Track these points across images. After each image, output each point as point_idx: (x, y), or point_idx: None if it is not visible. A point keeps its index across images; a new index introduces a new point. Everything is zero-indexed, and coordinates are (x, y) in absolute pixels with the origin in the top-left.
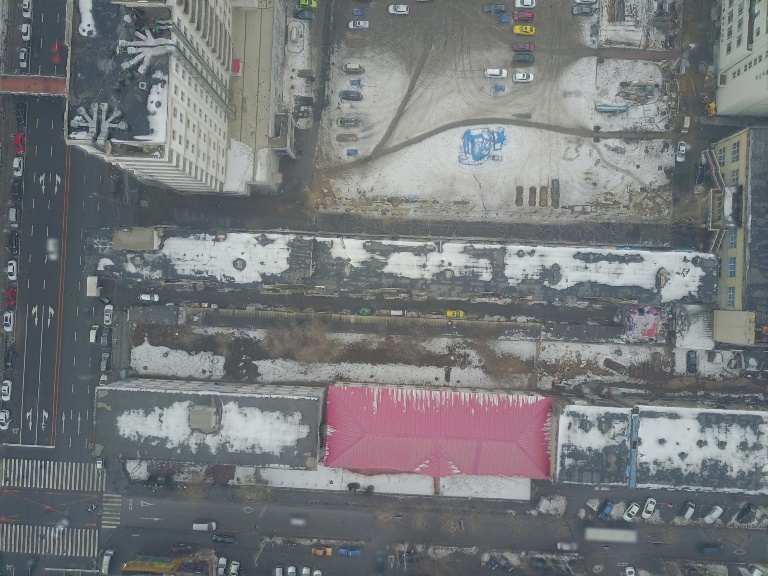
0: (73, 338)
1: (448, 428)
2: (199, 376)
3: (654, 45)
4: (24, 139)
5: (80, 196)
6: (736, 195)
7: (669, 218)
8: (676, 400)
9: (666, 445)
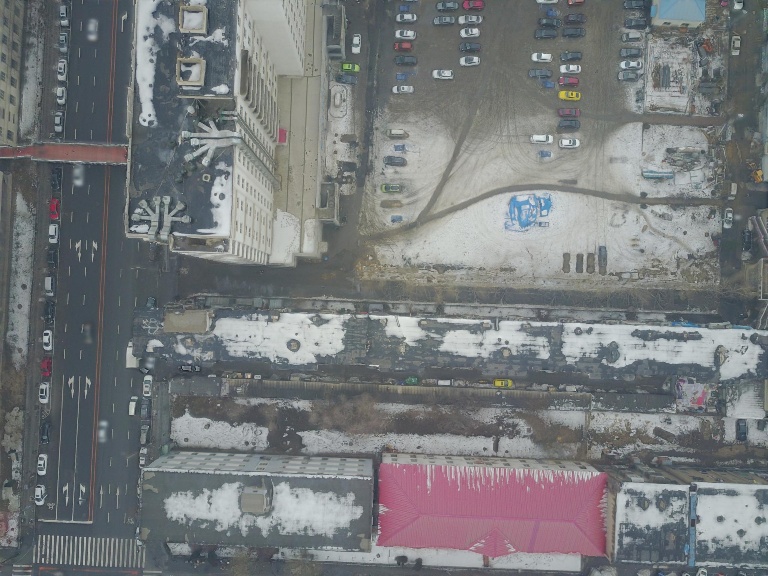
0: (111, 410)
1: (504, 507)
2: (242, 448)
3: (700, 111)
4: (59, 205)
5: (117, 263)
6: None
7: None
8: (728, 471)
9: (724, 522)
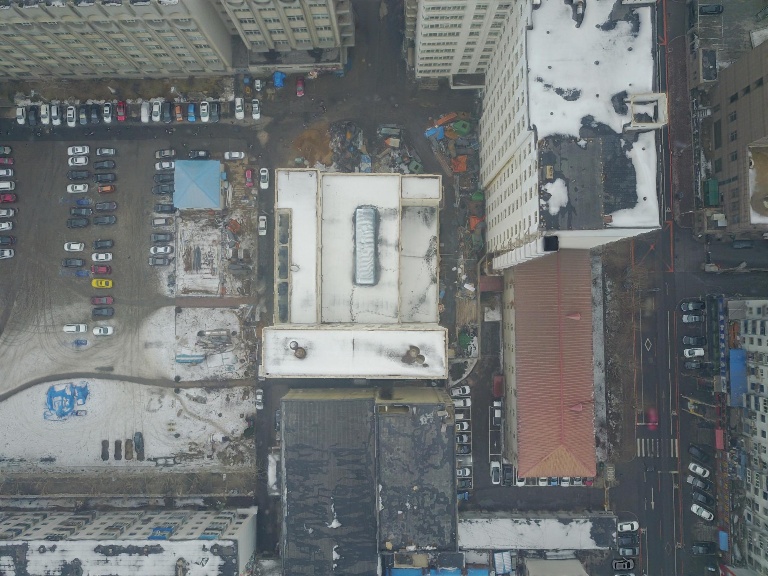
0: None
1: None
2: None
3: (231, 292)
4: None
5: None
6: (280, 463)
7: (253, 466)
8: None
9: None
